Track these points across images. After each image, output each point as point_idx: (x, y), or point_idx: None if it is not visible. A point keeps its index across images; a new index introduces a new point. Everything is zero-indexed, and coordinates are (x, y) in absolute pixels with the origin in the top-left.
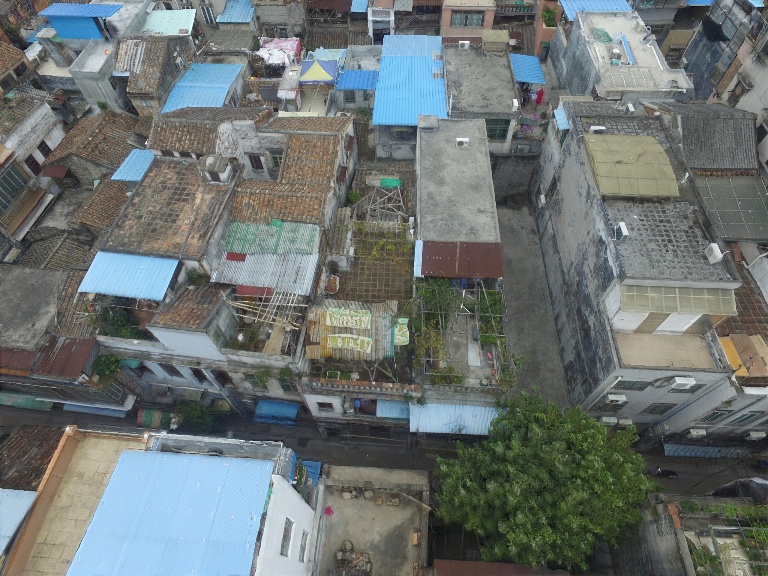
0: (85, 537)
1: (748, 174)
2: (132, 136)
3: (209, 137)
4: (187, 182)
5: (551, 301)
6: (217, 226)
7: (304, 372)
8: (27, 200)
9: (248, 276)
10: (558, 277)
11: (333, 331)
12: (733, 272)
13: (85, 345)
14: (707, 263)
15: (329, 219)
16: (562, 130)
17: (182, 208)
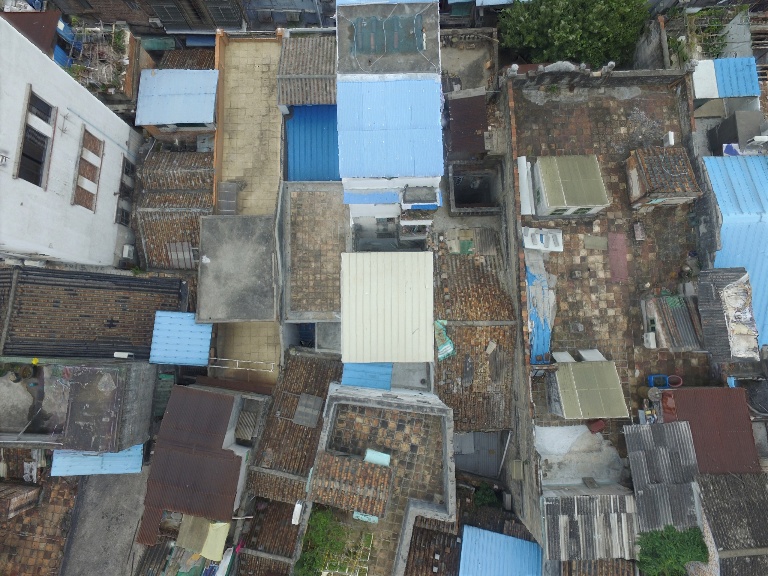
0: None
1: None
2: None
3: None
4: None
5: None
6: None
7: None
8: None
9: None
10: None
11: None
12: None
13: None
14: None
15: None
16: None
17: None
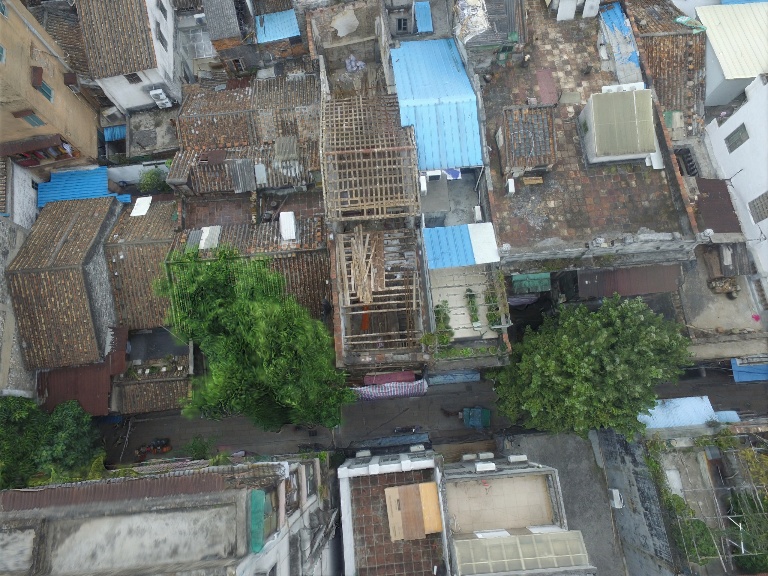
0: None
1: None
2: None
3: None
4: None
5: None
6: None
7: None
8: None
9: None
10: None
11: None
12: None
13: None
14: None
15: None
16: None
17: None
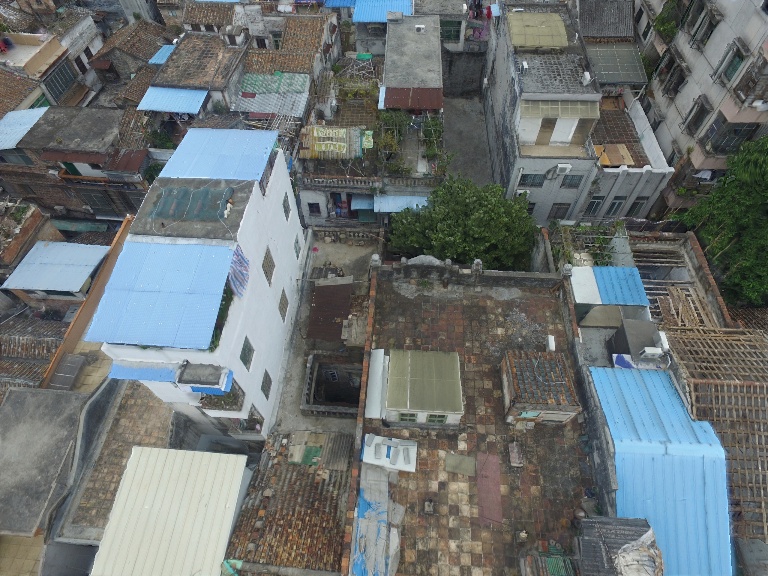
0: (173, 155)
1: (627, 41)
2: (161, 40)
3: (228, 14)
4: (211, 47)
5: (490, 156)
6: (235, 72)
7: (298, 172)
8: (77, 91)
9: (258, 107)
10: (493, 132)
11: (319, 140)
12: (598, 89)
13: (140, 153)
14: (582, 86)
15: (317, 75)
16: (497, 20)
17: (209, 61)
